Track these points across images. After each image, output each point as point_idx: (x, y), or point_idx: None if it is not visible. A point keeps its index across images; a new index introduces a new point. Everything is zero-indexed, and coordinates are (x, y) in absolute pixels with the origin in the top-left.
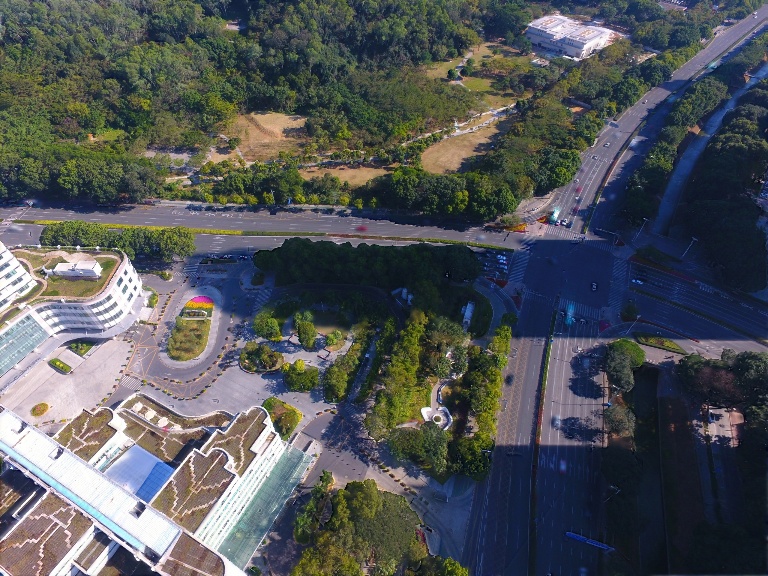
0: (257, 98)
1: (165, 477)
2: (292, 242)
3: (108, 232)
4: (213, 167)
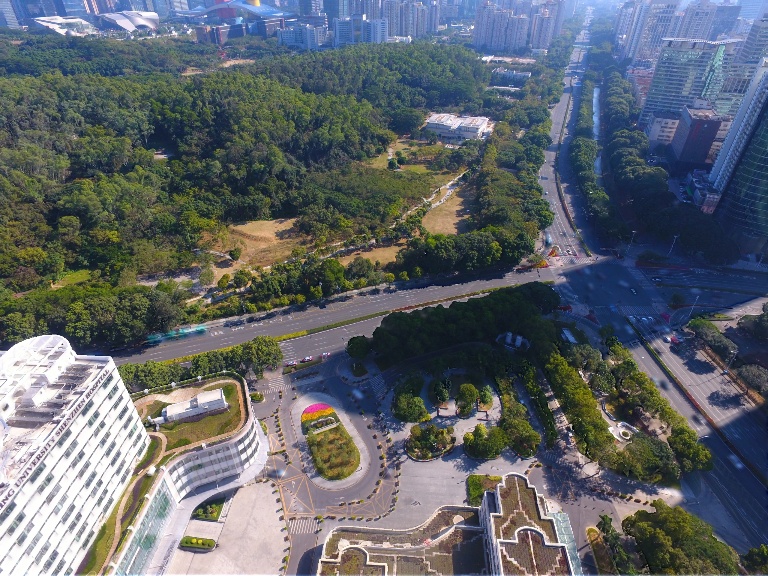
0: (233, 210)
1: None
2: (395, 317)
3: (170, 367)
4: (238, 277)
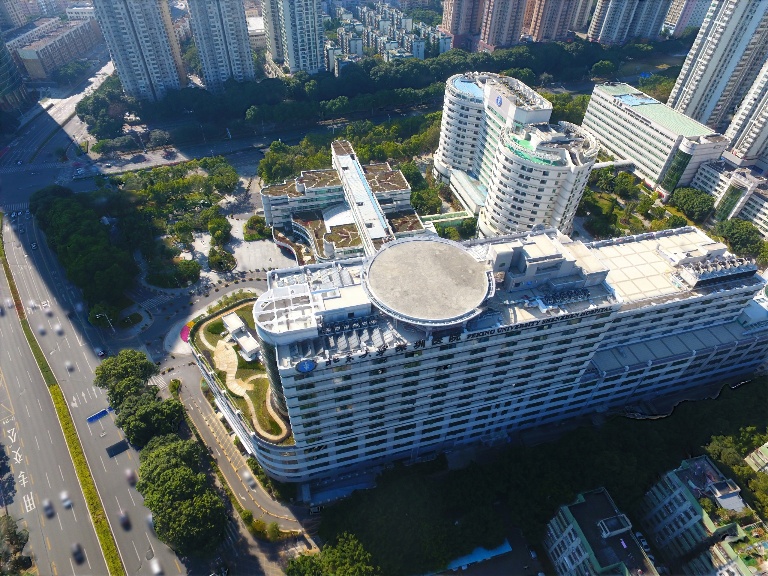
0: None
1: (329, 212)
2: (84, 264)
3: None
4: None
